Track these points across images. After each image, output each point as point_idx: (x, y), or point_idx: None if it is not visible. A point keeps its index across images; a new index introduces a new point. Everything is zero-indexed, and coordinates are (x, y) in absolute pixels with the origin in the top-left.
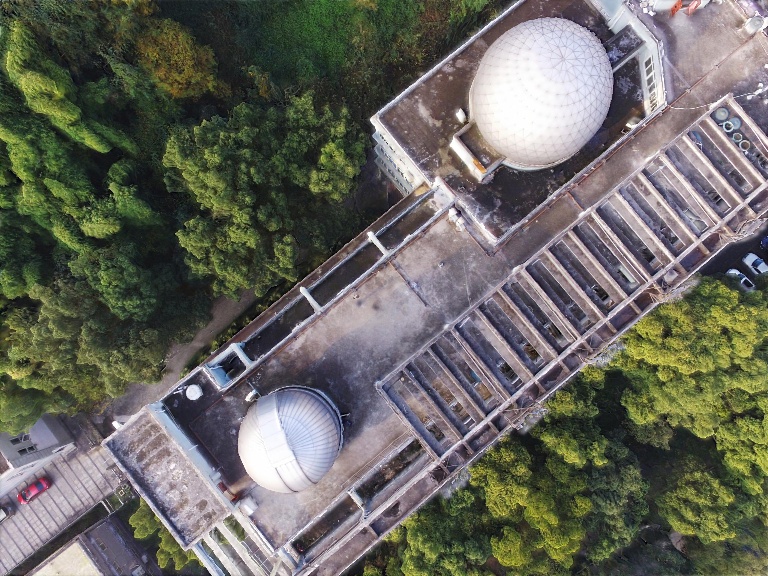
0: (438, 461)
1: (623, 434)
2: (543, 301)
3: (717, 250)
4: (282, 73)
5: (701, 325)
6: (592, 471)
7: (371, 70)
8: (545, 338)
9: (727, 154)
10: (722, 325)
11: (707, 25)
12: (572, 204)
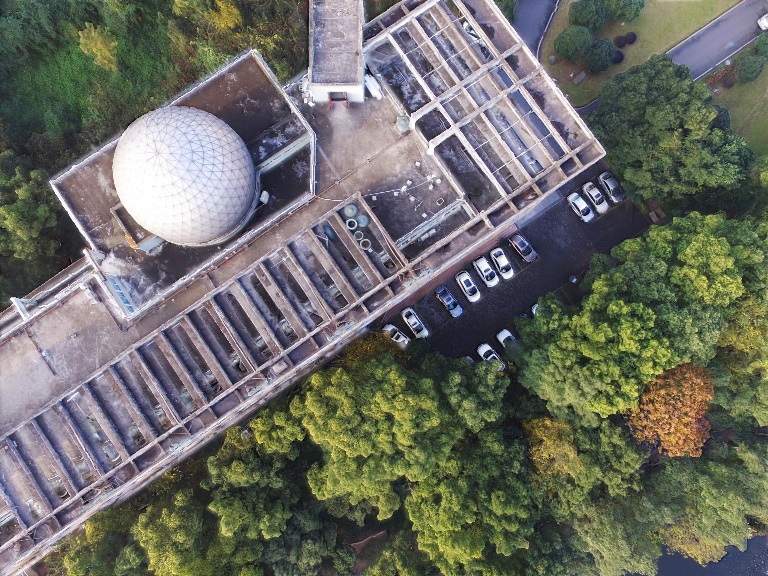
0: (24, 532)
1: (318, 506)
2: (152, 382)
3: (324, 346)
4: (31, 123)
5: (365, 410)
6: (270, 542)
7: (103, 129)
8: (148, 419)
9: (352, 251)
10: (386, 411)
11: (365, 119)
12: (210, 286)
